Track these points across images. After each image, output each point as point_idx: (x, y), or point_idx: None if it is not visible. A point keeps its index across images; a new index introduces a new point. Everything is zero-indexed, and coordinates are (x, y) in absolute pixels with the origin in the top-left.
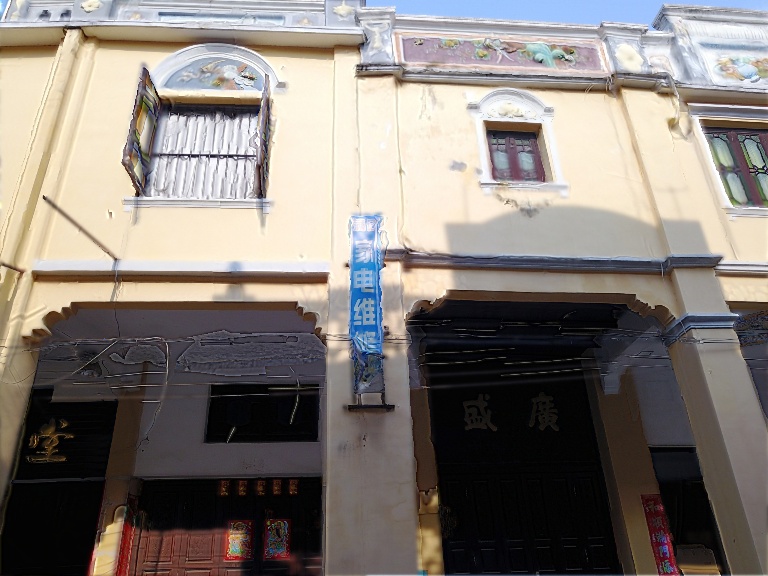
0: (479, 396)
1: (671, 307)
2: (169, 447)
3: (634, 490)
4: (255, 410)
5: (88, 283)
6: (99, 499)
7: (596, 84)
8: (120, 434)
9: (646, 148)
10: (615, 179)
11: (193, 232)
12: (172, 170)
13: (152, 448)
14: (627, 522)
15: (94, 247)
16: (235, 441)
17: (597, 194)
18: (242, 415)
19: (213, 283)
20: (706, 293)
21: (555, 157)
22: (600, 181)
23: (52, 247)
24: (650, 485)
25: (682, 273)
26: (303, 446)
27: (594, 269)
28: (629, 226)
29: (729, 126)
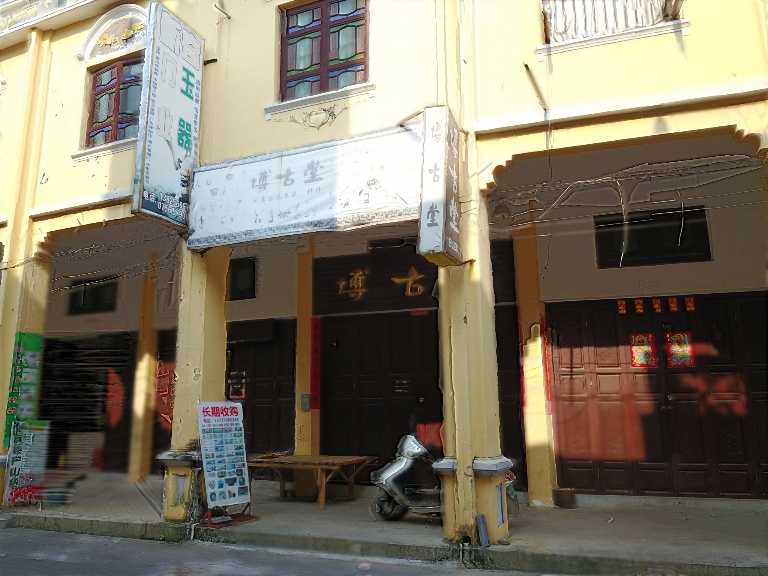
0: None
1: None
2: (566, 274)
3: None
4: (640, 236)
5: (524, 136)
6: (510, 319)
7: None
8: (521, 265)
9: None
10: None
11: (611, 70)
12: (569, 8)
13: (552, 276)
14: None
15: (521, 101)
16: (627, 265)
17: None
18: (628, 241)
19: (643, 118)
20: None
21: None
22: None
23: (482, 107)
24: None
25: None
26: (697, 266)
27: None
28: None
29: None
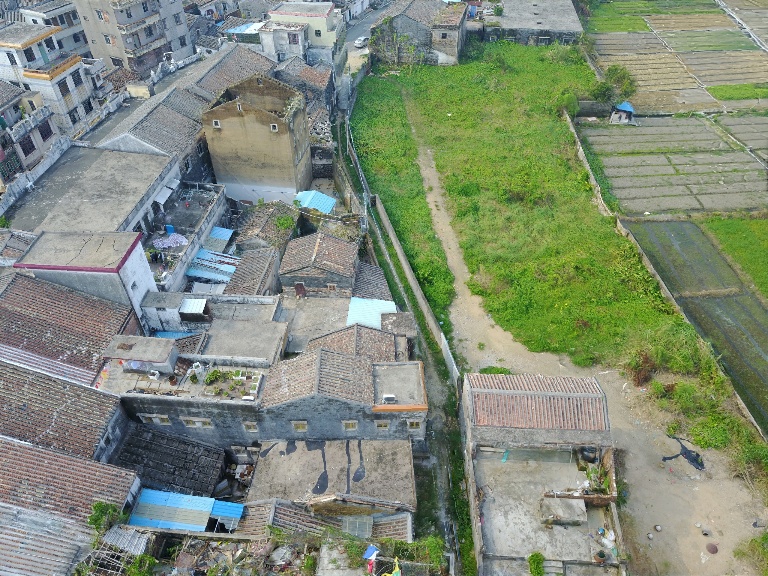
0: None
1: None
2: None
3: None
4: None
5: None
6: None
7: None
8: None
9: None
10: None
11: None
12: None
13: None
14: None
15: None
16: None
17: None
18: None
19: None
20: None
21: None
22: None
23: None
24: None
25: None
26: None
27: None
28: None
29: None
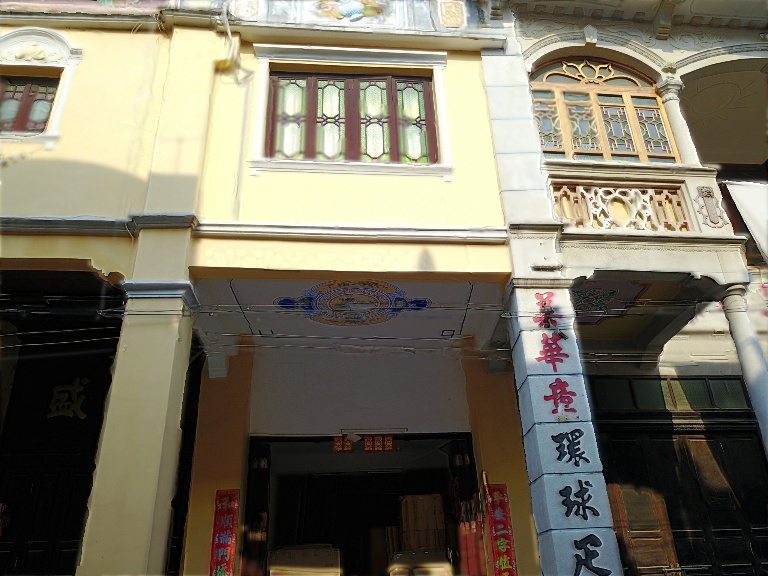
0: (75, 380)
1: (128, 274)
2: None
3: (210, 485)
4: None
5: None
6: None
7: (145, 23)
8: None
9: (171, 93)
10: (125, 129)
11: None
12: None
13: None
14: (190, 521)
15: None
16: None
17: (93, 146)
18: None
19: None
20: (166, 257)
21: (61, 104)
22: (105, 131)
23: None
24: (231, 479)
25: (148, 234)
26: None
27: (44, 230)
28: (114, 181)
29: (310, 70)
